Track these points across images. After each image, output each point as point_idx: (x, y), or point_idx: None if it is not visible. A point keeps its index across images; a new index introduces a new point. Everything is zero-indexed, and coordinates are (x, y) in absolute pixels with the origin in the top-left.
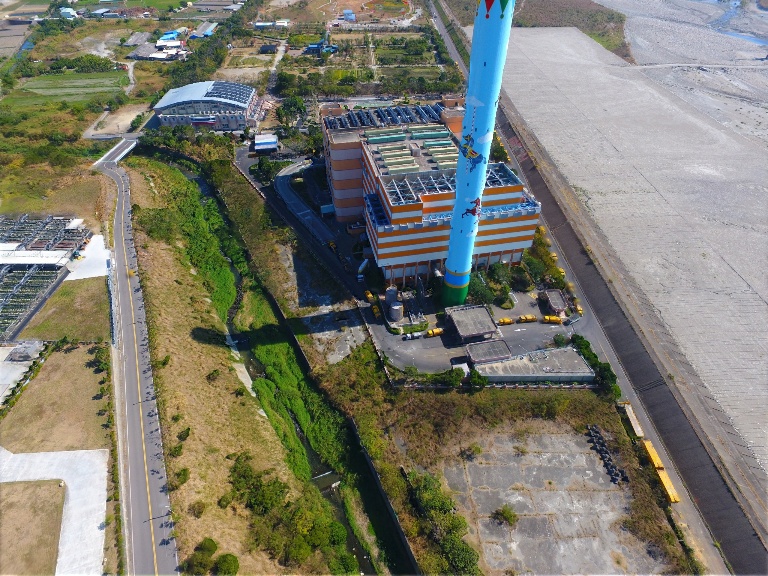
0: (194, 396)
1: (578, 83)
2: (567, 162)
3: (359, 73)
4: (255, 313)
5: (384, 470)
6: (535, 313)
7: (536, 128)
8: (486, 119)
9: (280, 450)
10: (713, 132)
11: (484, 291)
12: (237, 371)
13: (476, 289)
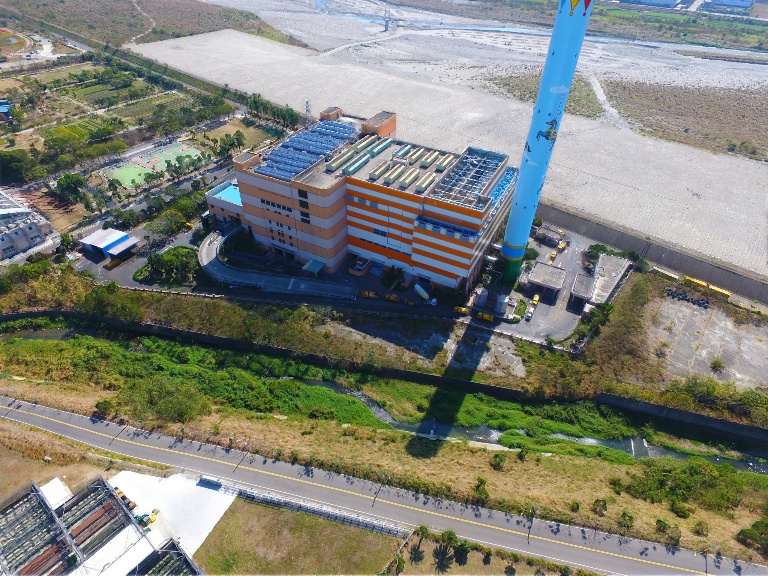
0: (530, 487)
1: (309, 77)
2: None
3: (93, 124)
4: (403, 397)
5: (669, 399)
6: (548, 250)
7: None
8: None
9: (598, 461)
10: (439, 88)
11: (532, 250)
12: None
13: None
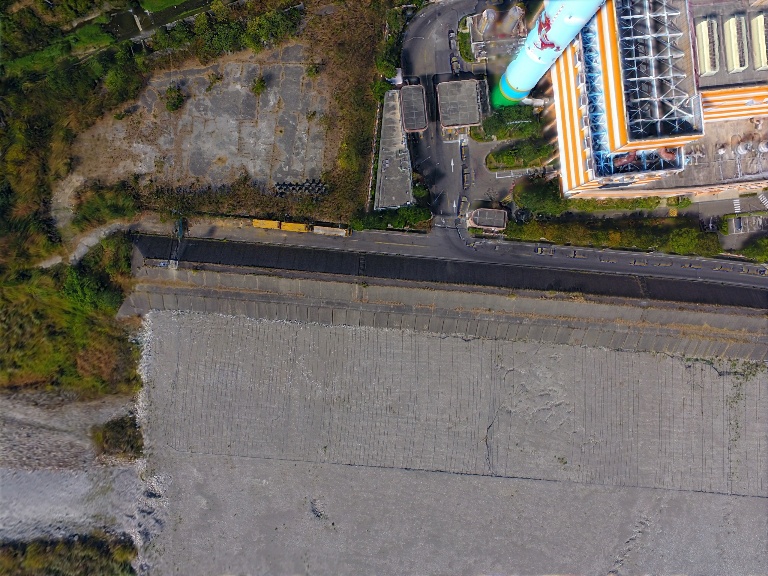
0: None
1: None
2: None
3: None
4: None
5: None
6: (477, 192)
7: None
8: None
9: None
10: None
11: None
12: None
13: (504, 113)
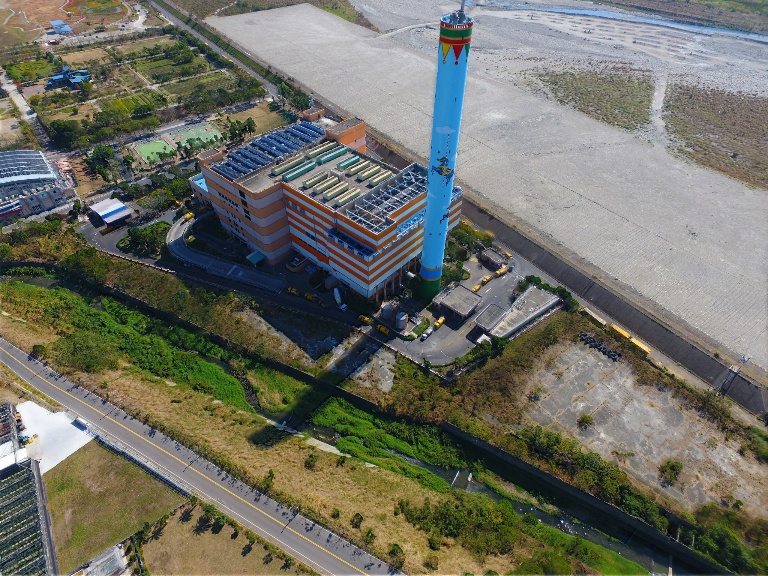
0: (319, 489)
1: (355, 61)
2: (406, 138)
3: (144, 98)
4: (276, 388)
5: (504, 442)
6: (486, 273)
7: (358, 114)
8: (456, 141)
9: (412, 482)
10: (478, 83)
11: (454, 273)
12: (316, 446)
13: (446, 274)
